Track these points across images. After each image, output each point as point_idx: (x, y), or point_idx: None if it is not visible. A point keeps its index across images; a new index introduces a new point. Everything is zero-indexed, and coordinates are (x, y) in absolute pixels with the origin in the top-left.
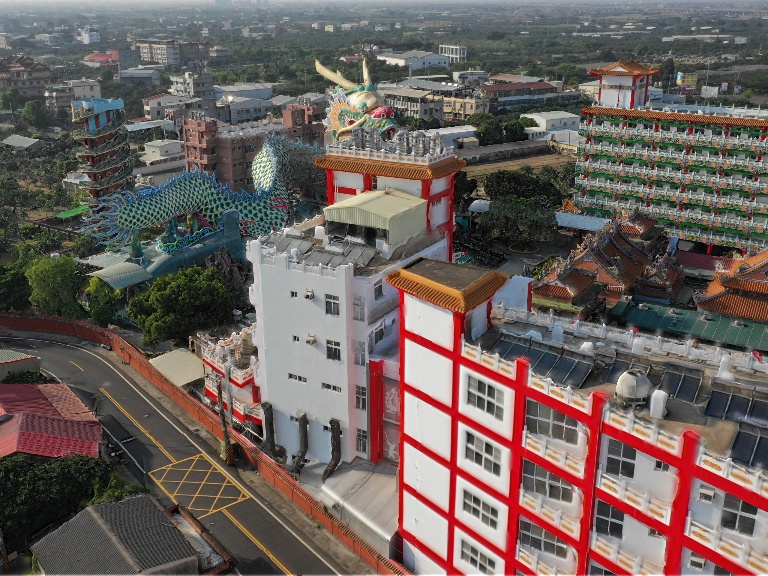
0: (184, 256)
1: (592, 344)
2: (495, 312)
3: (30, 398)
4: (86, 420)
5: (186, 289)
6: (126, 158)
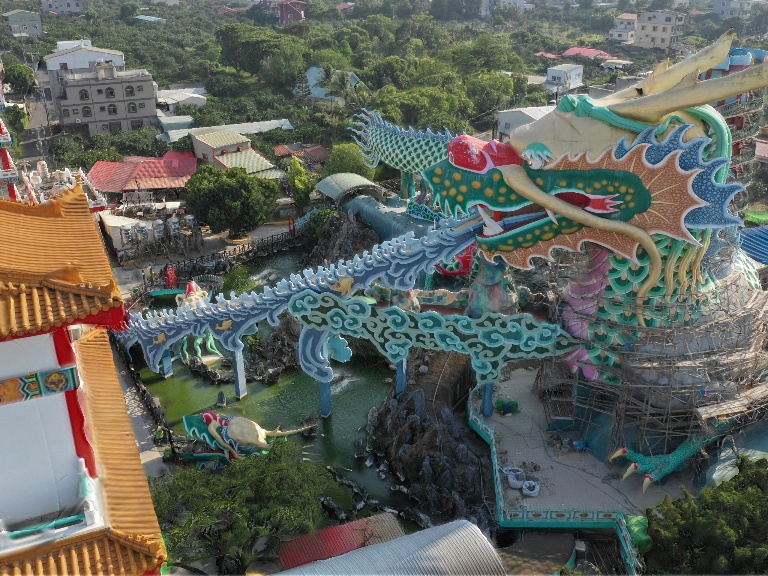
0: None
1: None
2: None
3: (170, 171)
4: (127, 186)
5: None
6: None
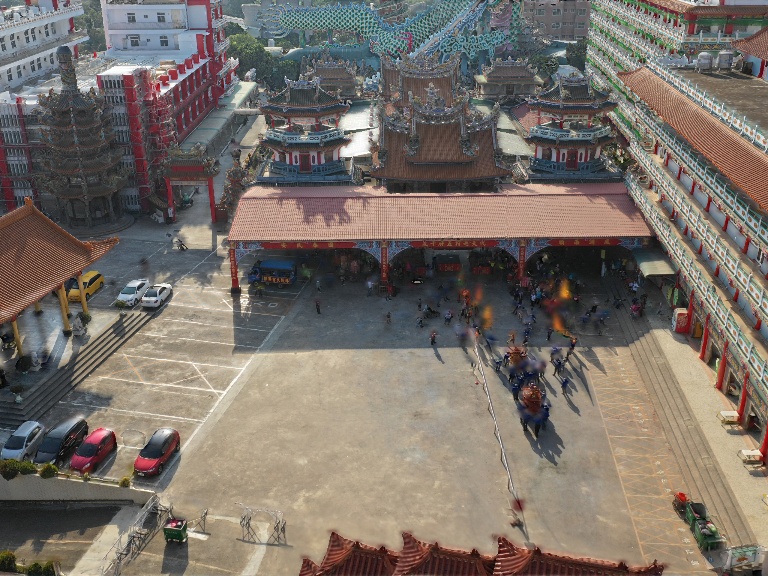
0: (310, 51)
1: (24, 8)
2: (72, 10)
3: None
4: None
5: (229, 48)
6: (395, 3)
